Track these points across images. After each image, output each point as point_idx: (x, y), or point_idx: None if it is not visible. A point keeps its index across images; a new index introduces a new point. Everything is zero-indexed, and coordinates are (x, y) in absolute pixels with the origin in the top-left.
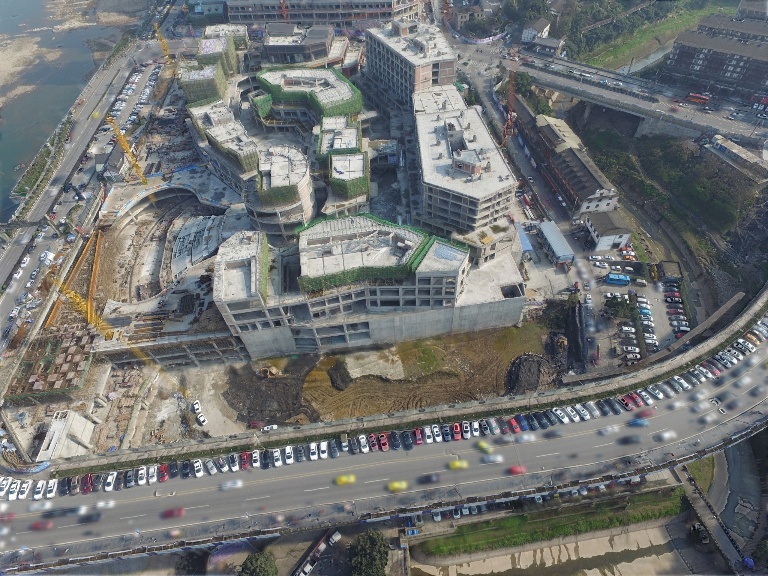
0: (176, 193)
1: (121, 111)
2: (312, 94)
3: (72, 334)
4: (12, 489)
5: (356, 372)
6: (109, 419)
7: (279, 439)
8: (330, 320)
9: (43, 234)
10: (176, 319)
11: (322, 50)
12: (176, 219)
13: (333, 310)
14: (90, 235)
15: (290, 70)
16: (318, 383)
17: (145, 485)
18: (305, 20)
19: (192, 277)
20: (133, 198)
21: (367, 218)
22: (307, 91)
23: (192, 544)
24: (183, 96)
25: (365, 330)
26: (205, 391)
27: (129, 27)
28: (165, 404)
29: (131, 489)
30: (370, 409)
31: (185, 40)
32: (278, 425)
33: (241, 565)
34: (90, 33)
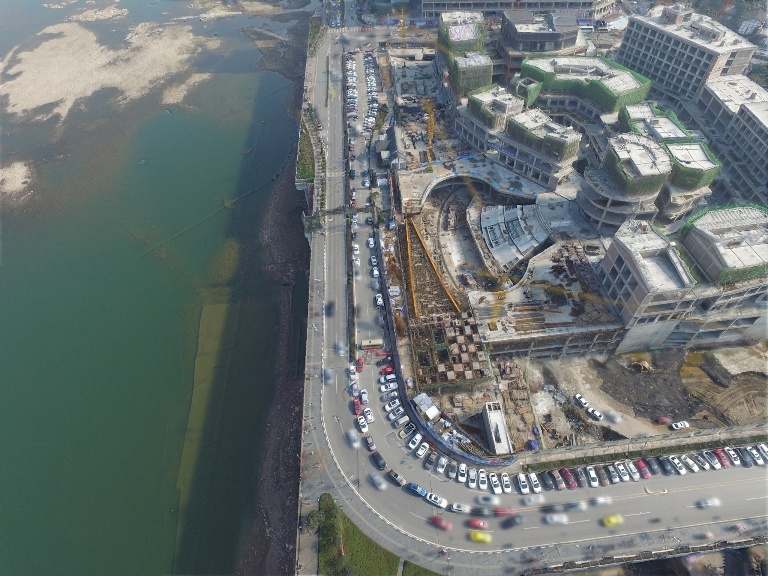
0: (452, 182)
1: (357, 98)
2: (599, 82)
3: (450, 323)
4: (496, 482)
5: (734, 368)
6: (508, 412)
7: (744, 436)
8: (722, 314)
9: (357, 221)
10: (553, 310)
11: (572, 38)
12: (468, 208)
13: (731, 304)
14: (404, 223)
15: (555, 58)
16: (697, 379)
17: (630, 481)
18: (501, 9)
19: (542, 267)
20: (428, 186)
21: (756, 209)
22: (582, 79)
23: (735, 545)
24: (412, 84)
25: (747, 325)
26: (580, 385)
27: (278, 16)
28: (538, 397)
29: (617, 485)
30: (767, 407)
31: (378, 28)
32: (687, 422)
33: (721, 567)
34: (240, 22)
